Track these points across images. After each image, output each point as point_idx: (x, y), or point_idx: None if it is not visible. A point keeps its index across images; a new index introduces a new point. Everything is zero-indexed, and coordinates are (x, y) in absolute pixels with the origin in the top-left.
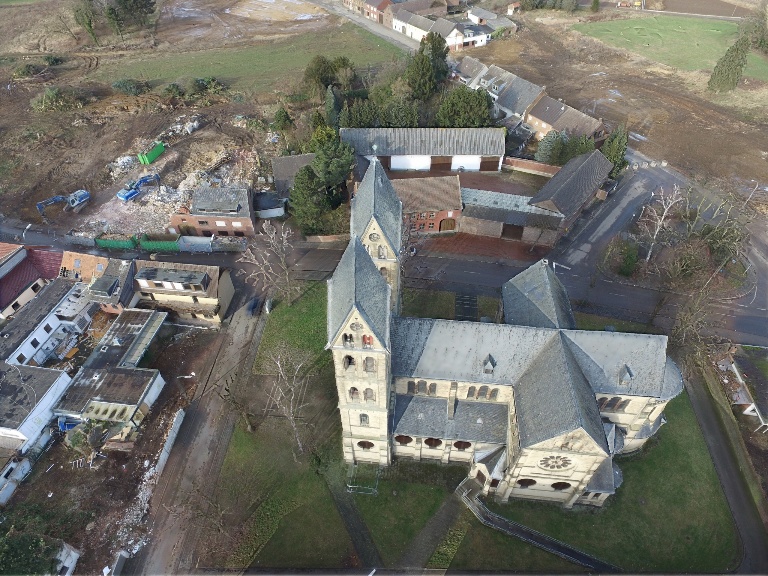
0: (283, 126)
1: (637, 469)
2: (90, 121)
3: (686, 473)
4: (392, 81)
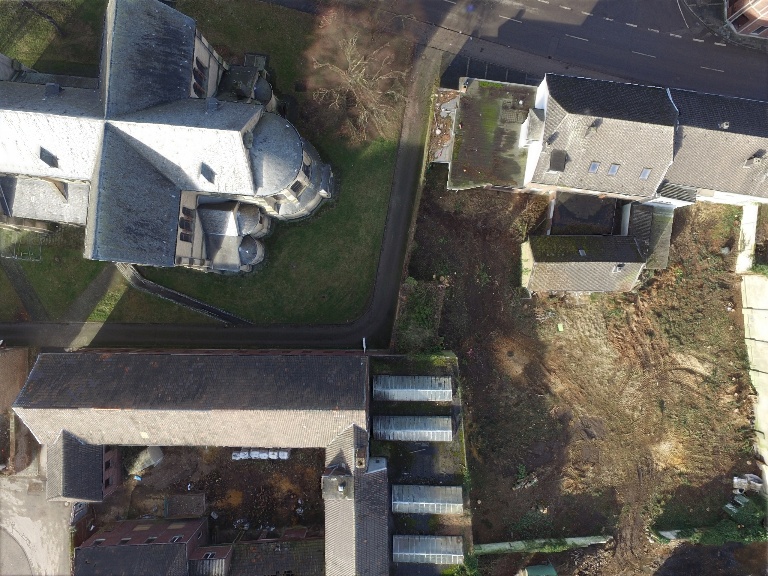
0: None
1: (300, 235)
2: None
3: (349, 238)
4: None
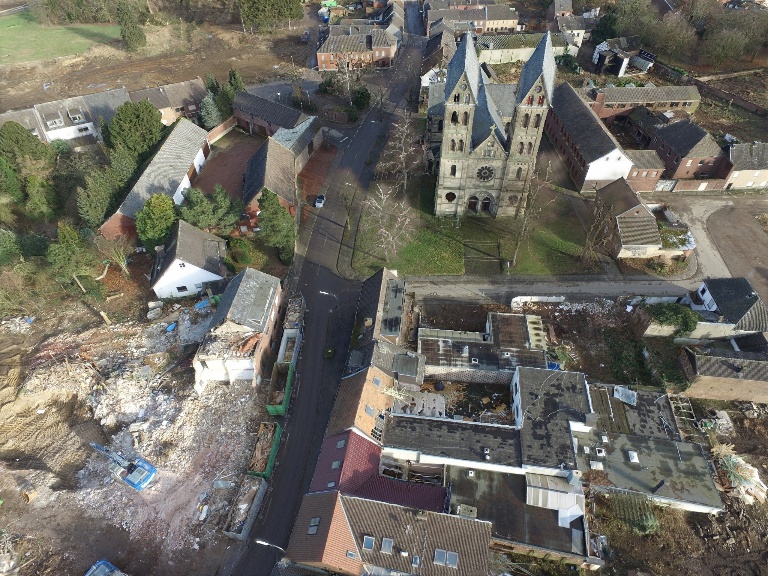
0: None
1: None
2: None
3: None
4: None
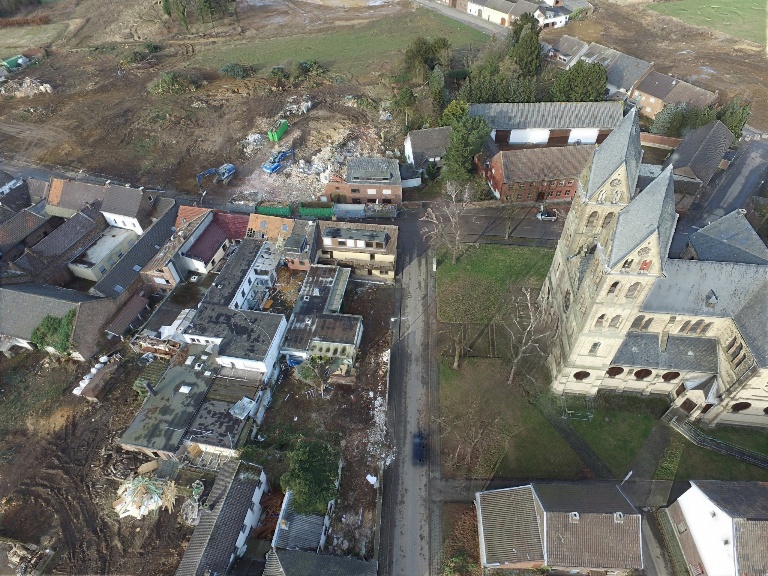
0: (407, 103)
1: None
2: (208, 103)
3: None
4: (494, 60)
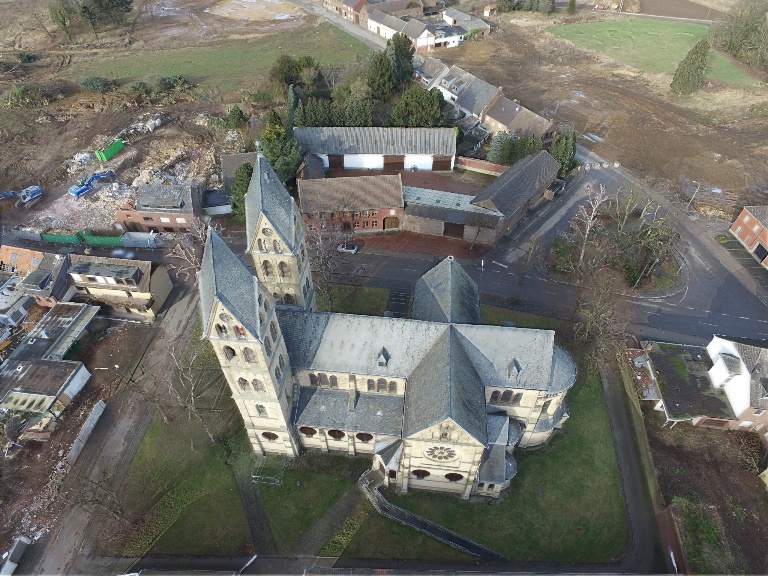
0: (238, 124)
1: (540, 462)
2: (54, 118)
3: (587, 466)
4: (354, 81)
